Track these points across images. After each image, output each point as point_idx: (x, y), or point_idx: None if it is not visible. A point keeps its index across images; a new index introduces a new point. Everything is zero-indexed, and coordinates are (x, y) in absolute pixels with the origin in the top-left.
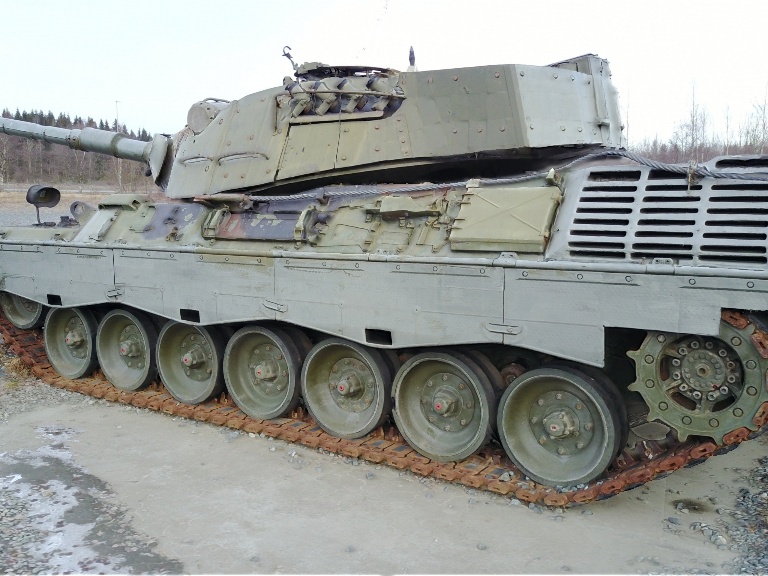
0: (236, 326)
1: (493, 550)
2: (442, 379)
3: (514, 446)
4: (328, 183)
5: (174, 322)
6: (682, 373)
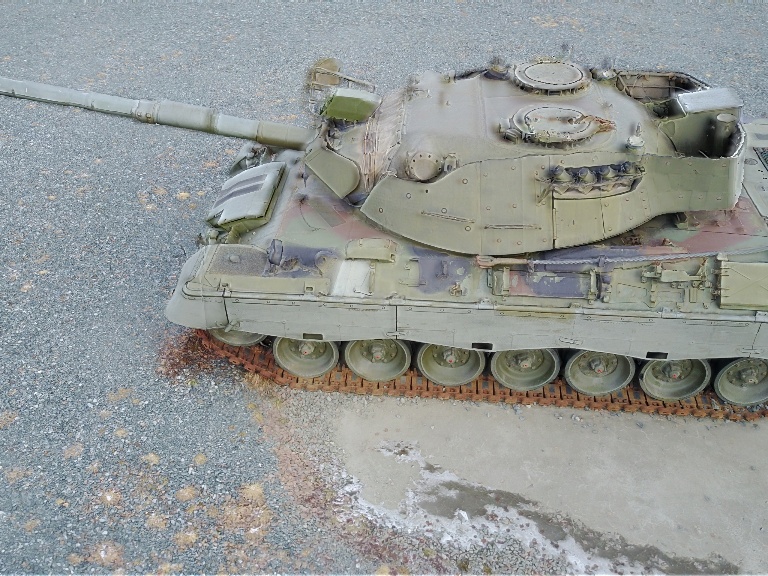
0: None
1: (758, 468)
2: None
3: None
4: (592, 244)
5: None
6: None
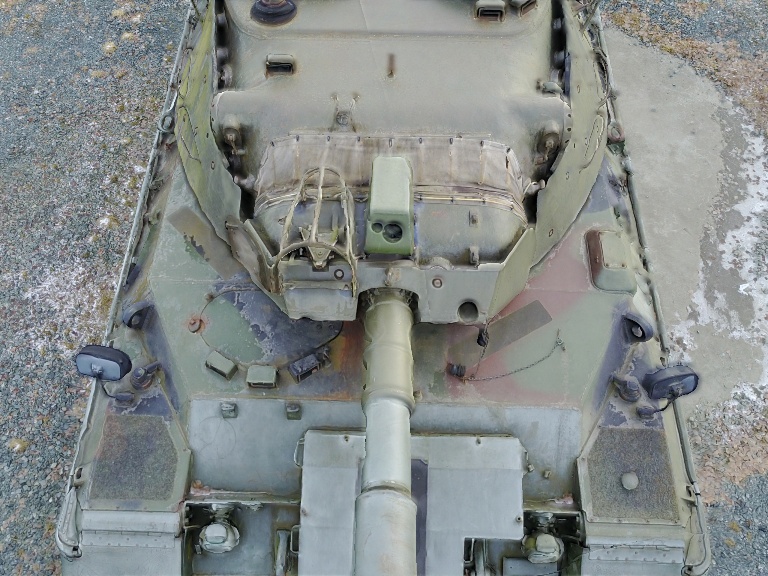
0: None
1: None
2: None
3: None
4: None
5: None
6: None
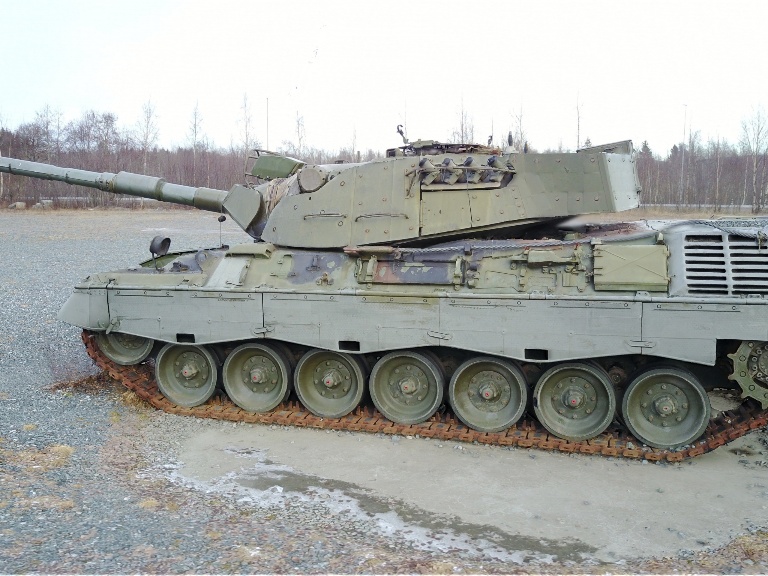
0: (387, 352)
1: (668, 492)
2: (571, 381)
3: (635, 424)
4: (463, 238)
5: (316, 351)
6: (759, 366)
